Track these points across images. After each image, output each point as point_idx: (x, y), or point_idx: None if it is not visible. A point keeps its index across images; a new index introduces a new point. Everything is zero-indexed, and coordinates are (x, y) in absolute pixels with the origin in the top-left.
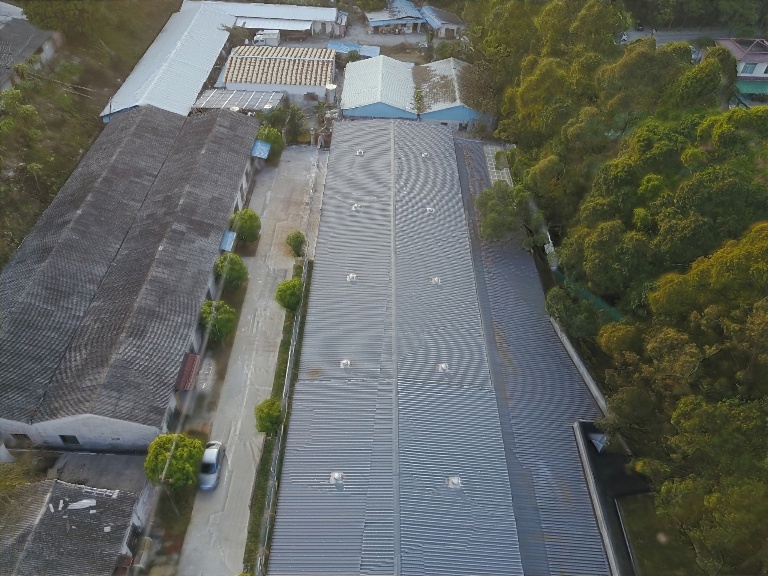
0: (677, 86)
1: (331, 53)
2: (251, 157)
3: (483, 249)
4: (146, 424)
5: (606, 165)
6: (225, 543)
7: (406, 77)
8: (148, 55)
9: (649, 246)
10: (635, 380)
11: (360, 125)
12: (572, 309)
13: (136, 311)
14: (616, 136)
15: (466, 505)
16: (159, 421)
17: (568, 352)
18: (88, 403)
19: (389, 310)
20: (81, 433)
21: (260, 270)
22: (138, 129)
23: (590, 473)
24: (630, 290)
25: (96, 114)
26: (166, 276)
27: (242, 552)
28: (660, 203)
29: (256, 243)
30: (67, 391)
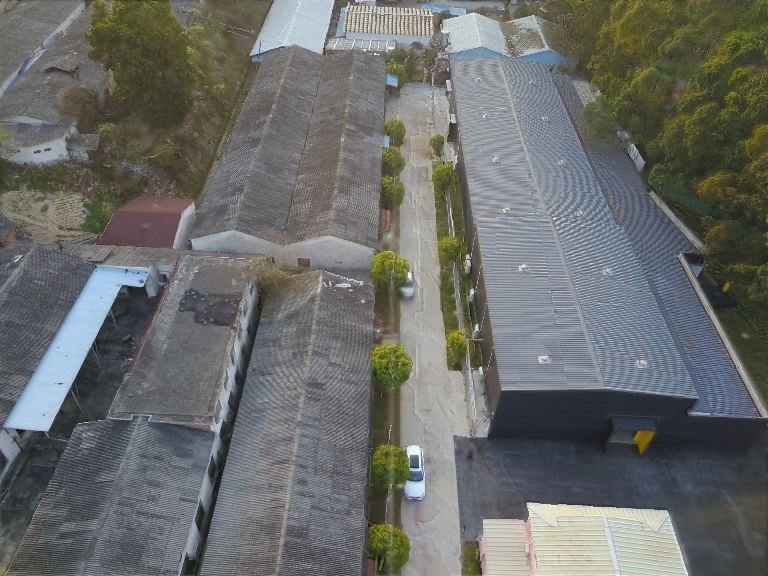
0: (756, 7)
1: (429, 11)
2: (385, 85)
3: (588, 149)
4: (368, 246)
5: (700, 68)
6: (430, 328)
7: (497, 30)
8: (273, 12)
9: (740, 116)
10: (734, 206)
11: (472, 61)
12: (671, 179)
13: (339, 178)
14: (702, 53)
15: (618, 284)
16: (375, 245)
17: (666, 214)
18: (326, 230)
19: (531, 179)
20: (315, 256)
21: (406, 167)
22: (293, 62)
23: (696, 281)
24: (724, 152)
25: (243, 56)
26: (352, 158)
27: (443, 334)
28: (748, 86)
29: (398, 149)
30: (304, 225)
